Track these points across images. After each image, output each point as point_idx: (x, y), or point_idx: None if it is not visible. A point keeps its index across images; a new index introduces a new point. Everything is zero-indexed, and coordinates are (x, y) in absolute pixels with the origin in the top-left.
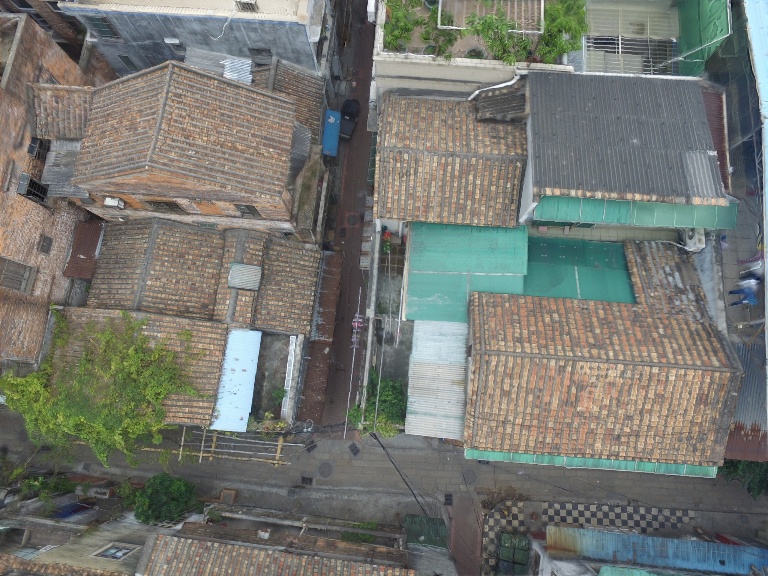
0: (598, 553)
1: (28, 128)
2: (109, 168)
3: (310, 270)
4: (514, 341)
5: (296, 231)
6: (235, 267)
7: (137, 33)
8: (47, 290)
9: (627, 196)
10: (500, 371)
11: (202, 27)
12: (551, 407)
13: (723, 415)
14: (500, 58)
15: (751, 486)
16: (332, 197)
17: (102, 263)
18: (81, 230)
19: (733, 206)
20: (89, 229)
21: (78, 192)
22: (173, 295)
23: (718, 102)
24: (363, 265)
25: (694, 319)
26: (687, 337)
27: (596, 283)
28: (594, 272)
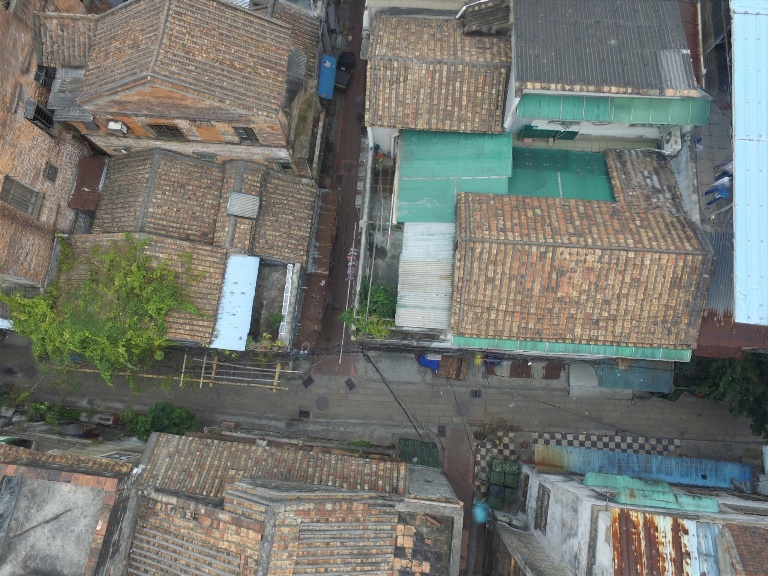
0: (584, 469)
1: (34, 55)
2: (113, 84)
3: (306, 204)
4: (498, 231)
5: (293, 161)
6: (234, 196)
7: None
8: (53, 218)
9: (604, 89)
10: (484, 258)
11: None
12: (533, 293)
13: (696, 298)
14: None
15: (733, 406)
16: (328, 143)
17: (105, 195)
18: (85, 165)
19: (706, 103)
20: (93, 164)
21: (83, 116)
22: (174, 223)
23: (693, 10)
24: (358, 203)
25: (670, 213)
26: (662, 228)
27: (578, 187)
28: (576, 177)
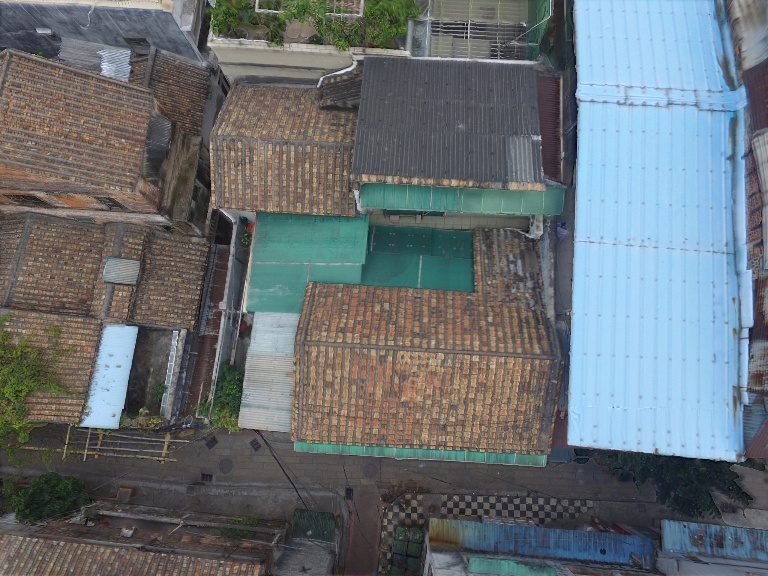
0: (480, 545)
1: None
2: None
3: (196, 264)
4: (337, 331)
5: (173, 224)
6: (111, 261)
7: (7, 23)
8: None
9: (443, 182)
10: (321, 362)
11: (69, 16)
12: (375, 398)
13: (546, 403)
14: (334, 43)
15: (635, 475)
16: None
17: None
18: None
19: (560, 191)
20: None
21: None
22: (47, 291)
23: (554, 86)
24: None
25: (526, 307)
26: (515, 325)
27: (439, 272)
28: (439, 261)
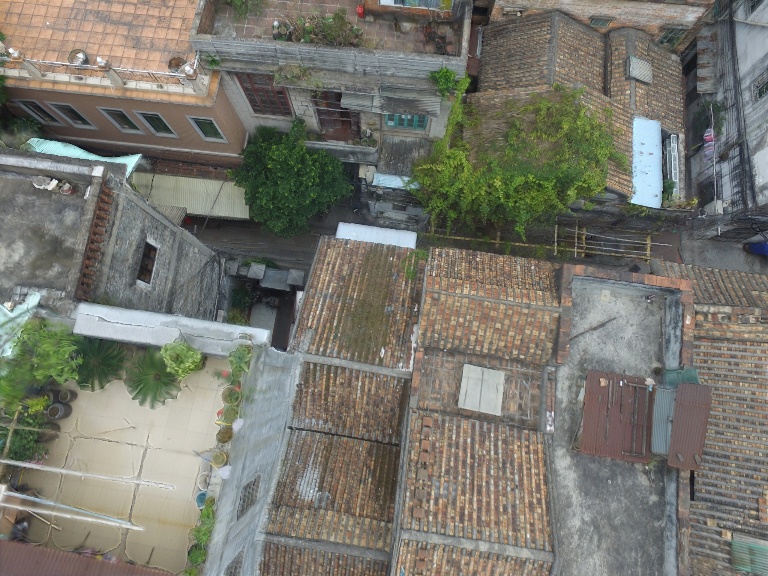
0: None
1: None
2: None
3: (677, 79)
4: None
5: (692, 28)
6: (634, 60)
7: None
8: None
9: None
10: None
11: None
12: None
13: None
14: None
15: None
16: None
17: (491, 60)
18: None
19: None
20: None
21: None
22: None
23: None
24: (702, 89)
25: None
26: None
27: None
28: None
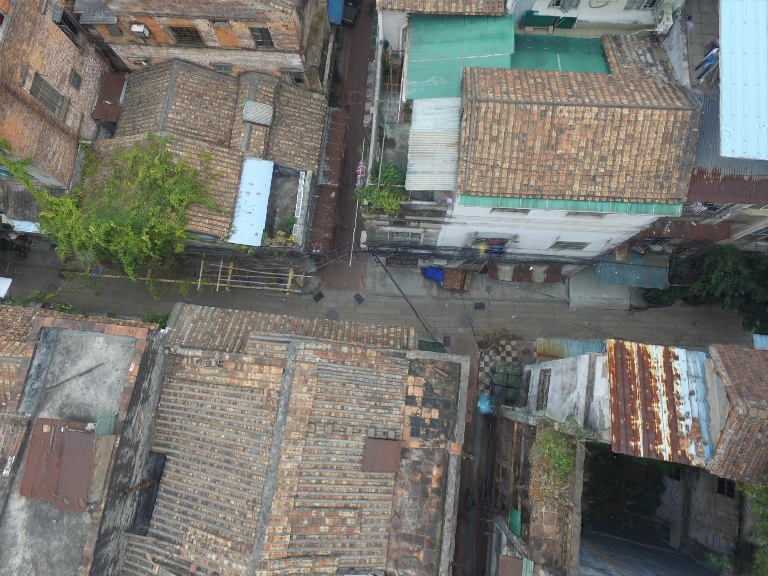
0: None
1: None
2: None
3: (317, 117)
4: (501, 93)
5: (305, 71)
6: (249, 103)
7: None
8: (77, 125)
9: None
10: (489, 117)
11: None
12: (534, 151)
13: (686, 152)
14: None
15: (725, 302)
16: (337, 72)
17: (126, 106)
18: (106, 80)
19: None
20: (113, 79)
21: (107, 18)
22: (192, 129)
23: None
24: (366, 122)
25: (662, 81)
26: (655, 91)
27: (576, 65)
28: (574, 58)
